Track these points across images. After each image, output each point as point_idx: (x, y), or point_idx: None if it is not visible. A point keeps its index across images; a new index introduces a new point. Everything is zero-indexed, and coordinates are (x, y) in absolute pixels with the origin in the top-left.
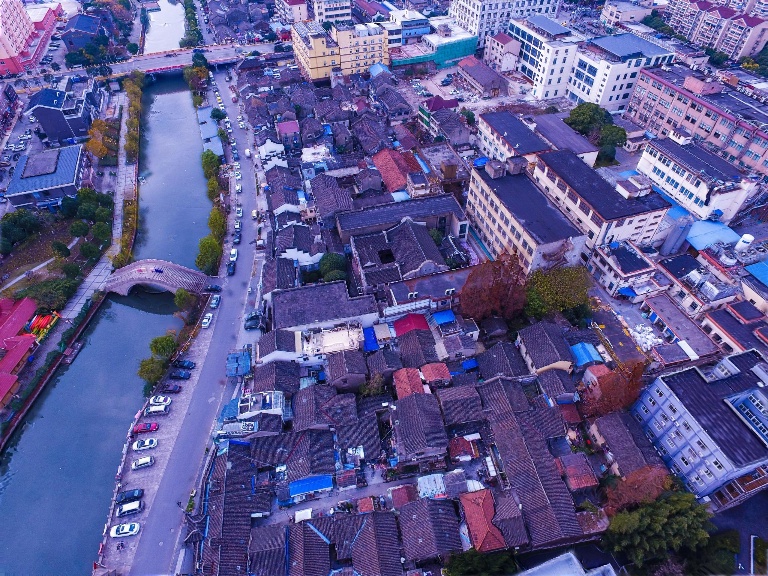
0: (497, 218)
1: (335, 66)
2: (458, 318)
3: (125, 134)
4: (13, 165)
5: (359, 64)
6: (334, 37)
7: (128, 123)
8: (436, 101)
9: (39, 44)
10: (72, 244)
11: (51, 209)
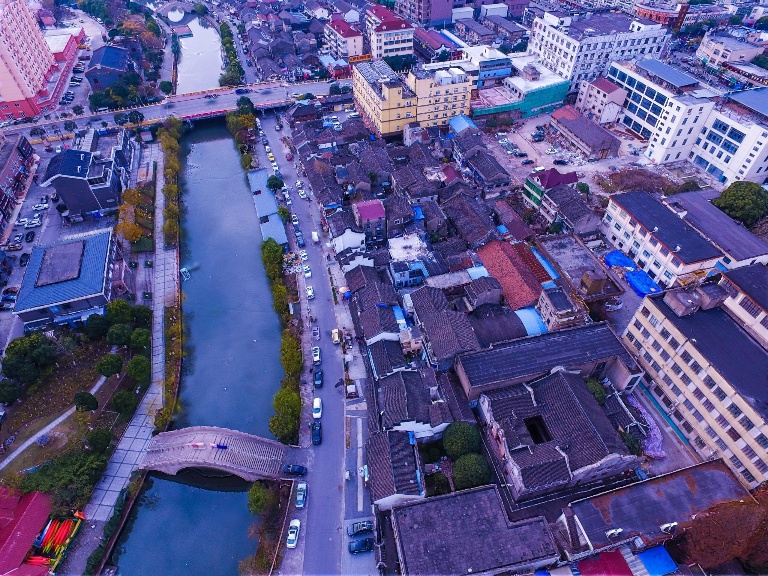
0: (696, 380)
1: (410, 118)
2: (685, 572)
3: (164, 210)
4: (25, 248)
5: (437, 116)
6: (410, 84)
7: (166, 191)
8: (551, 175)
9: (59, 79)
10: (99, 382)
11: (72, 324)
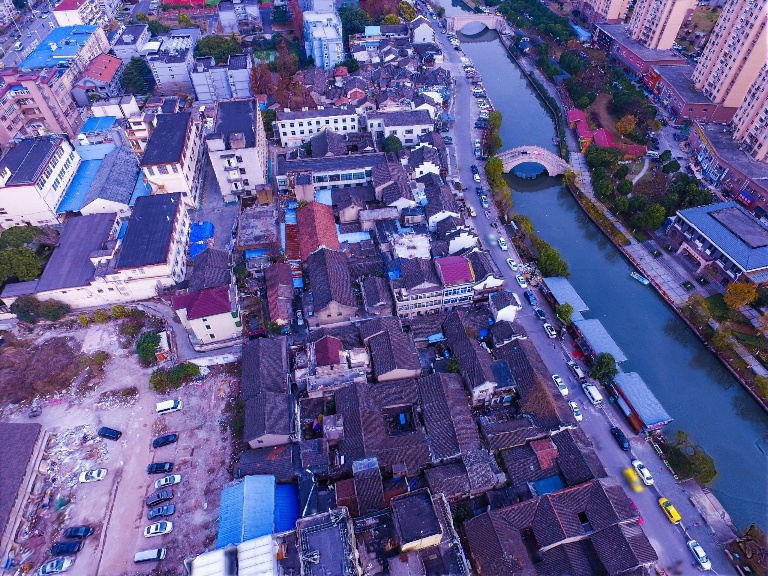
0: None
1: None
2: None
3: None
4: None
5: None
6: (360, 571)
7: None
8: (211, 289)
9: None
10: (630, 195)
11: None
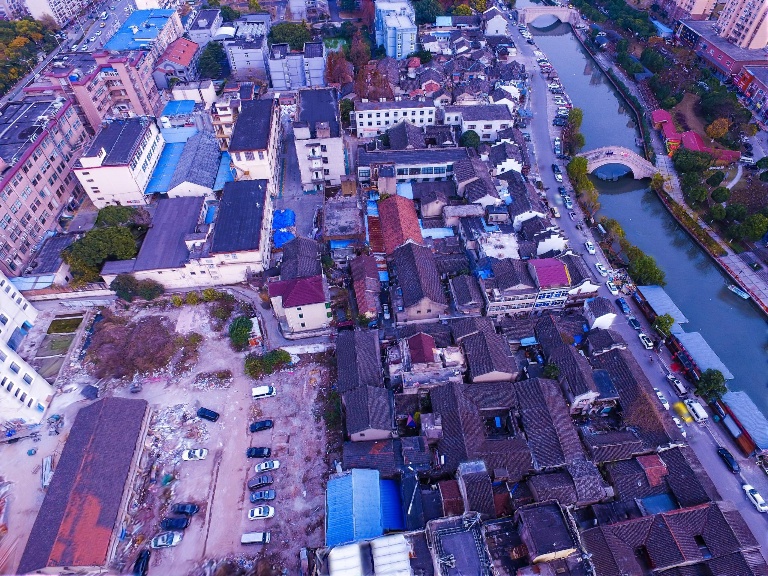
0: None
1: None
2: None
3: None
4: None
5: None
6: None
7: None
8: None
9: None
10: (724, 203)
11: None
